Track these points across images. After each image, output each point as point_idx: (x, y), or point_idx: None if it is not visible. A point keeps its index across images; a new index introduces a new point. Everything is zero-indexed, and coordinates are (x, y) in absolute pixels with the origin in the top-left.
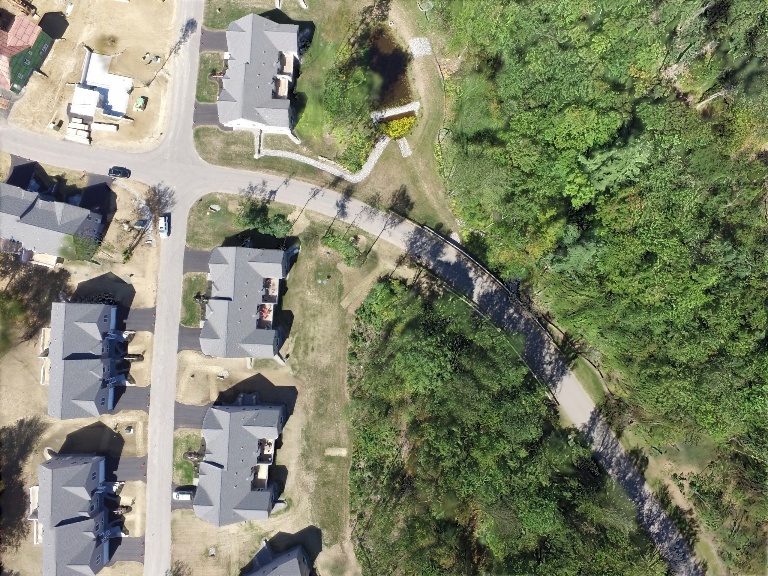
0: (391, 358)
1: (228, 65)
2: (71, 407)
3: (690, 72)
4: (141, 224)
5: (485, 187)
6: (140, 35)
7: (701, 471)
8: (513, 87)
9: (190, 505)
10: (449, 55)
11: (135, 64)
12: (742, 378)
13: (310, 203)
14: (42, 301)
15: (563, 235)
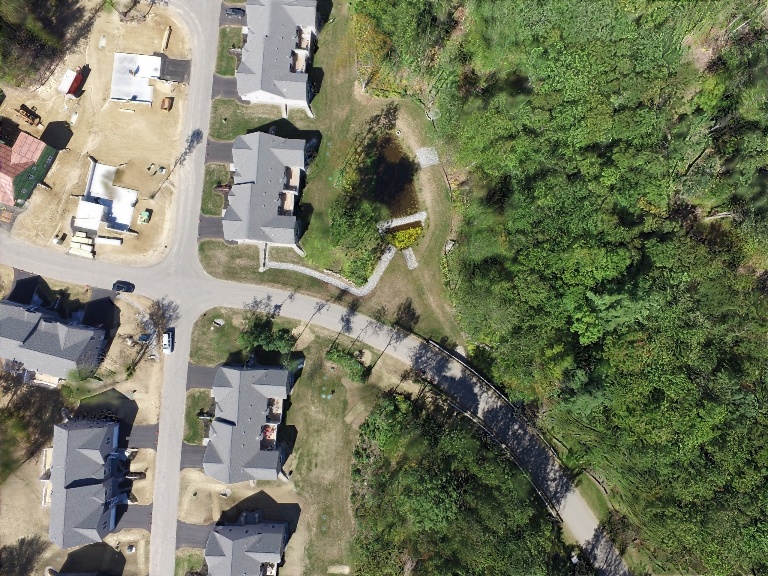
0: (395, 475)
1: (234, 180)
2: (73, 535)
3: (698, 184)
4: (144, 339)
5: (492, 311)
6: (145, 145)
7: None
8: (522, 222)
9: None
10: (456, 164)
11: (140, 175)
12: (748, 516)
13: (315, 318)
14: (44, 418)
15: (570, 379)
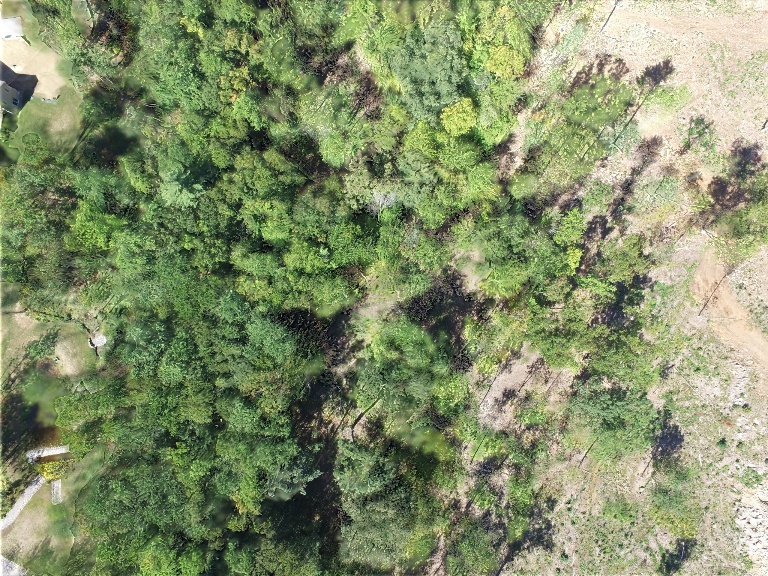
0: None
1: None
2: None
3: (368, 435)
4: None
5: None
6: None
7: None
8: None
9: None
10: None
11: None
12: None
13: None
14: None
15: None
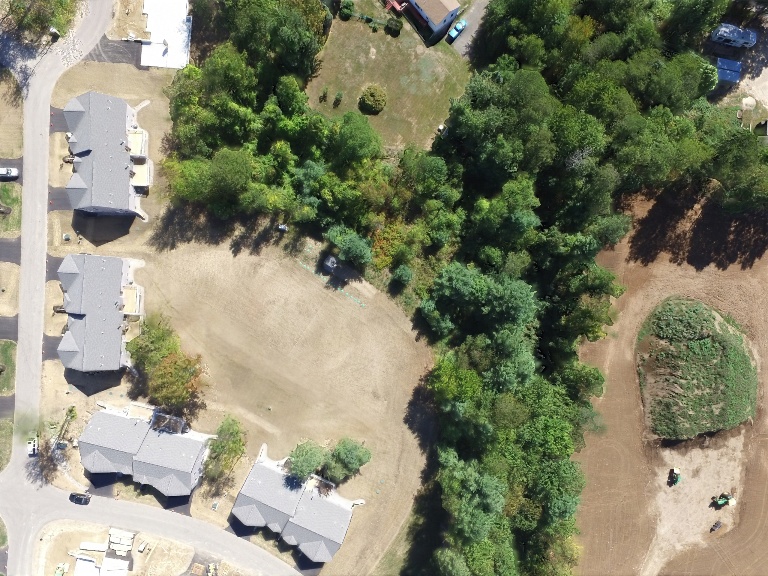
0: None
1: None
2: None
3: None
4: None
5: None
6: None
7: None
8: None
9: (4, 162)
10: None
11: None
12: None
13: None
14: None
15: None
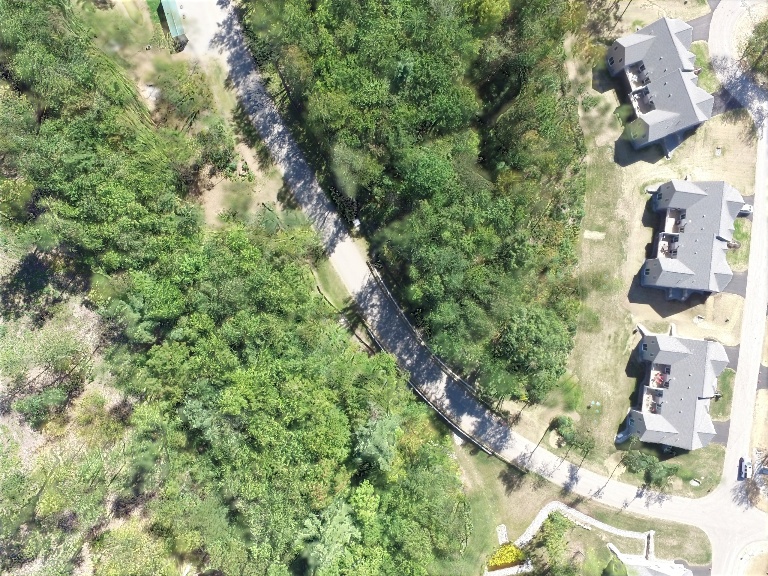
0: None
1: None
2: None
3: None
4: (765, 471)
5: None
6: None
7: (222, 182)
8: None
9: None
10: None
11: None
12: (203, 292)
13: (604, 483)
14: None
15: None
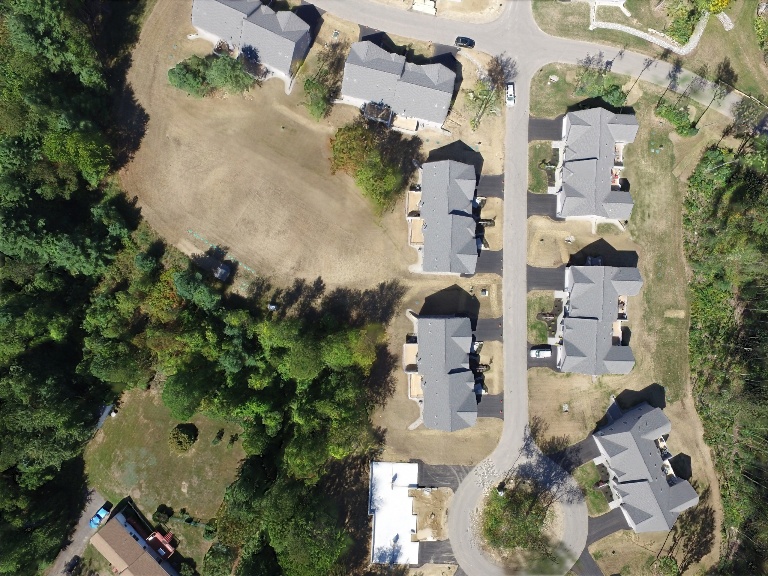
0: (723, 224)
1: None
2: (456, 261)
3: None
4: None
5: None
6: None
7: None
8: None
9: (545, 363)
10: None
11: None
12: None
13: (644, 73)
14: (396, 168)
15: None
